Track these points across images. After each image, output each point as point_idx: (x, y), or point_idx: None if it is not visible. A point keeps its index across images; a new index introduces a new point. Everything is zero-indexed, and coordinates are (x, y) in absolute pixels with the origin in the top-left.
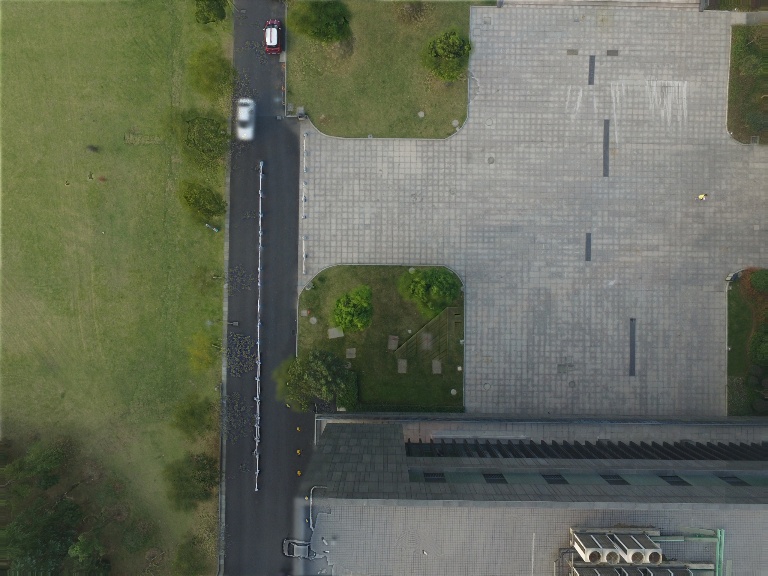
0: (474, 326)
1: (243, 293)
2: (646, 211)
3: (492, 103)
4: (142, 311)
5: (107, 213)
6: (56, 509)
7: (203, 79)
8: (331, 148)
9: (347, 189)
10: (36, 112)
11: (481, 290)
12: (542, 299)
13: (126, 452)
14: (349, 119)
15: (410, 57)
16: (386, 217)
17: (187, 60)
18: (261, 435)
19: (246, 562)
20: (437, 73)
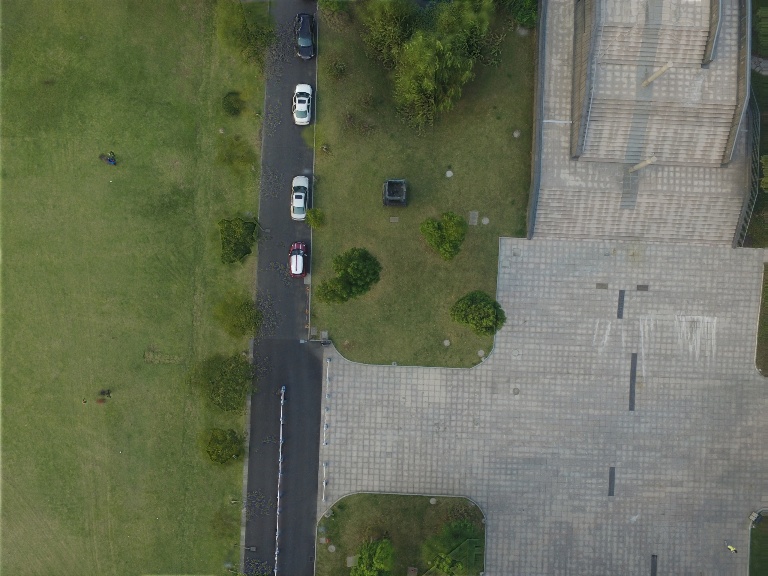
0: (494, 559)
1: (261, 518)
2: (671, 446)
3: (519, 334)
4: (158, 533)
5: (125, 432)
6: None
7: (225, 298)
8: (354, 374)
9: (369, 416)
10: (54, 327)
11: (502, 522)
12: (564, 533)
13: None
14: (373, 346)
15: (437, 286)
16: (408, 446)
17: (209, 278)
18: None
19: None
20: (464, 304)
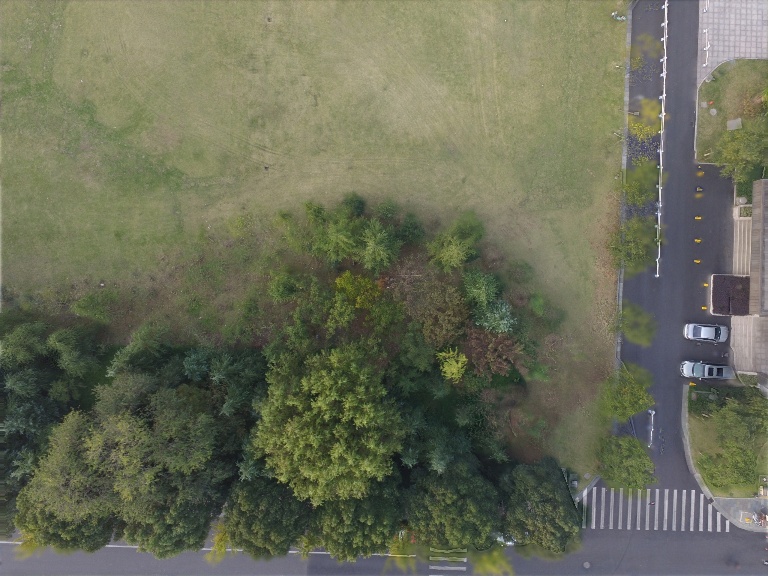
0: None
1: (644, 83)
2: None
3: None
4: (543, 99)
5: (509, 2)
6: (491, 275)
7: None
8: None
9: None
10: None
11: None
12: None
13: (526, 238)
14: None
15: None
16: None
17: None
18: (661, 223)
19: (643, 349)
20: None
